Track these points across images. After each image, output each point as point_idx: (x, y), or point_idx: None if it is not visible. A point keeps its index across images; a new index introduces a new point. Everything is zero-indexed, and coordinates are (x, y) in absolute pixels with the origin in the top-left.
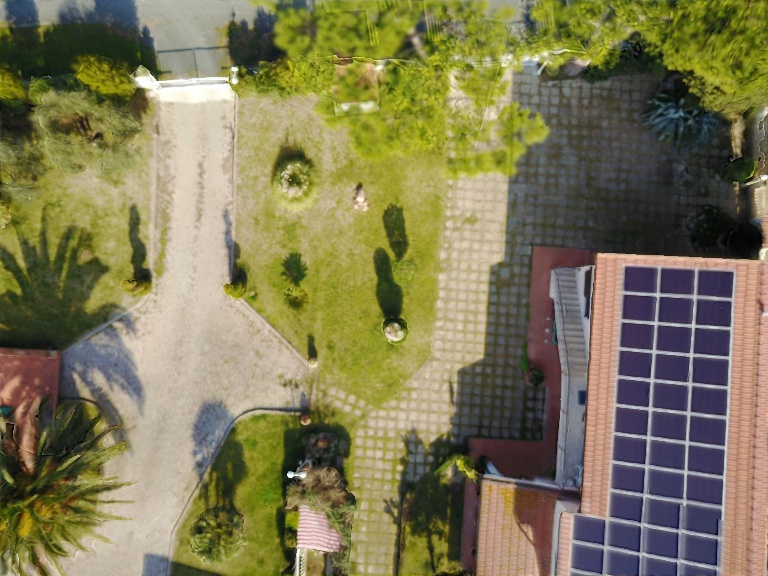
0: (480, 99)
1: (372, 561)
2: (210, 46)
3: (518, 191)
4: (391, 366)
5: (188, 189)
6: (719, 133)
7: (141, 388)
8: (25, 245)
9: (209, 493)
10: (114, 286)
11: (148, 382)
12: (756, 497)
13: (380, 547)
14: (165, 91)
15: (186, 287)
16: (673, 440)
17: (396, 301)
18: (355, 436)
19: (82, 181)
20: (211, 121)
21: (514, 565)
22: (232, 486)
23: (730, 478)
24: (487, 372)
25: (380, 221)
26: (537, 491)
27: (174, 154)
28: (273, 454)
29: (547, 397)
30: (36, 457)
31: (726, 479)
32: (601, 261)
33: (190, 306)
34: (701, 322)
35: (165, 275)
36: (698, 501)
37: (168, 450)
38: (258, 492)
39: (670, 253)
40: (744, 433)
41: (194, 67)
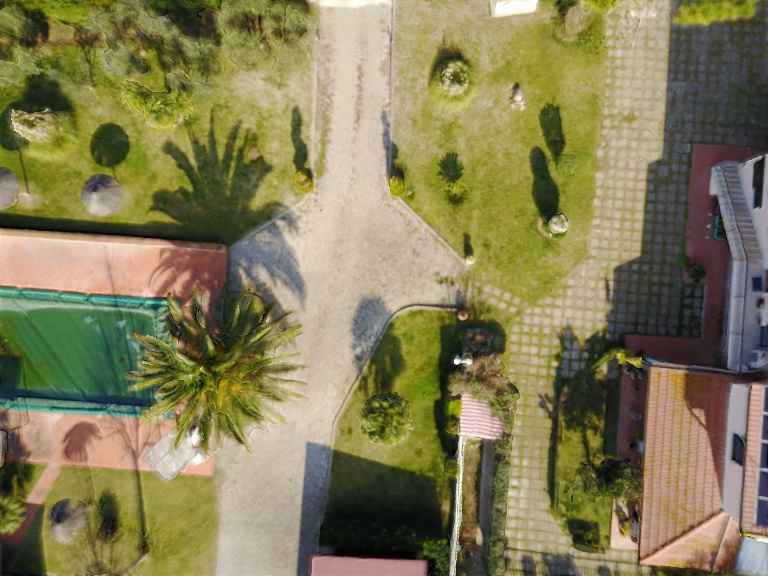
0: None
1: (527, 454)
2: None
3: (677, 89)
4: (547, 264)
5: (346, 91)
6: None
7: (303, 283)
8: (196, 144)
9: (369, 385)
10: (278, 185)
11: (309, 278)
12: None
13: (535, 441)
14: None
15: (345, 187)
16: None
17: (552, 200)
18: (510, 332)
19: (247, 83)
20: (369, 25)
21: (686, 450)
22: (391, 378)
23: None
24: (644, 270)
25: (536, 121)
26: (711, 376)
27: (333, 57)
28: (430, 349)
29: (706, 295)
30: (222, 335)
31: None
32: None
33: (349, 205)
34: None
35: (325, 175)
36: None
37: (329, 343)
38: (416, 385)
39: None
40: None
41: None
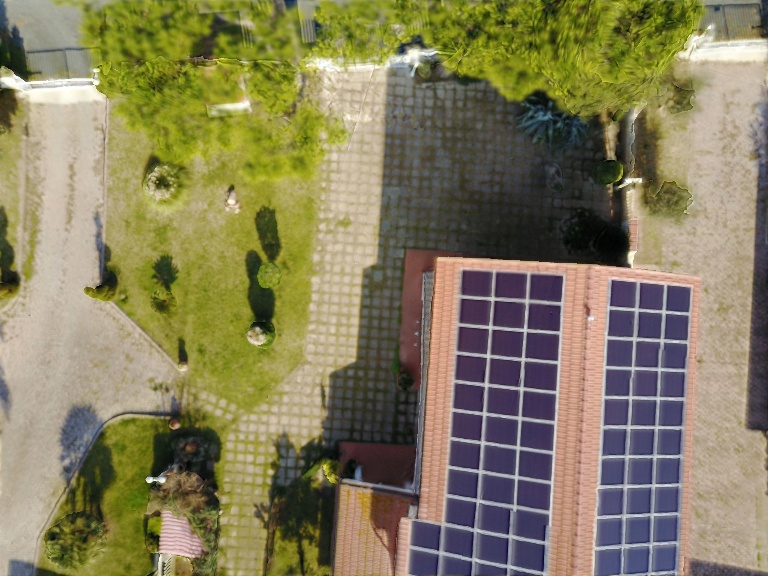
0: (354, 101)
1: (242, 566)
2: (81, 47)
3: (391, 194)
4: (262, 370)
5: (58, 191)
6: (593, 136)
7: (8, 392)
8: None
9: (76, 498)
10: None
11: (15, 386)
12: (582, 503)
13: (250, 552)
14: (34, 92)
15: (55, 290)
16: (505, 445)
17: (268, 304)
18: (226, 440)
19: None
20: (82, 122)
21: (369, 571)
22: (100, 491)
23: (557, 483)
24: (359, 376)
25: (252, 224)
26: (392, 496)
27: (44, 156)
28: (142, 459)
29: (419, 401)
30: None
31: (554, 484)
32: (440, 265)
33: (59, 309)
34: (532, 326)
35: (34, 278)
36: (527, 507)
37: (35, 455)
38: (126, 497)
39: (544, 256)
40: (571, 438)
41: (65, 68)
